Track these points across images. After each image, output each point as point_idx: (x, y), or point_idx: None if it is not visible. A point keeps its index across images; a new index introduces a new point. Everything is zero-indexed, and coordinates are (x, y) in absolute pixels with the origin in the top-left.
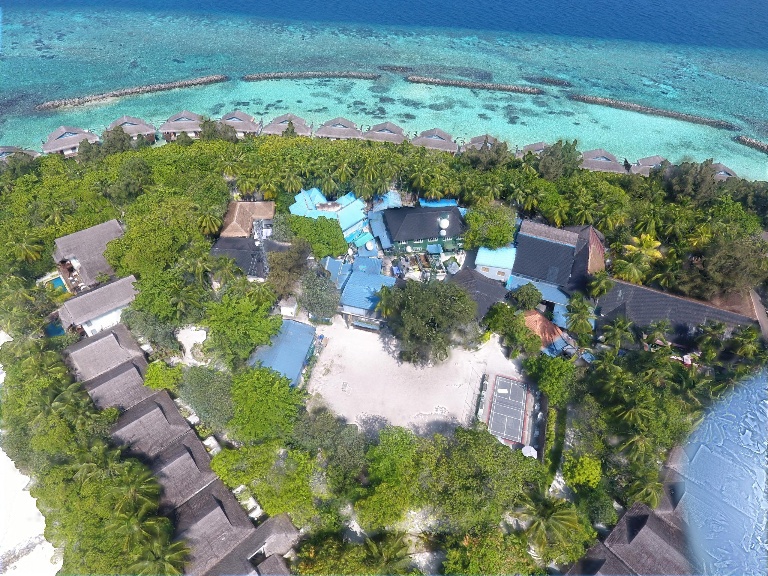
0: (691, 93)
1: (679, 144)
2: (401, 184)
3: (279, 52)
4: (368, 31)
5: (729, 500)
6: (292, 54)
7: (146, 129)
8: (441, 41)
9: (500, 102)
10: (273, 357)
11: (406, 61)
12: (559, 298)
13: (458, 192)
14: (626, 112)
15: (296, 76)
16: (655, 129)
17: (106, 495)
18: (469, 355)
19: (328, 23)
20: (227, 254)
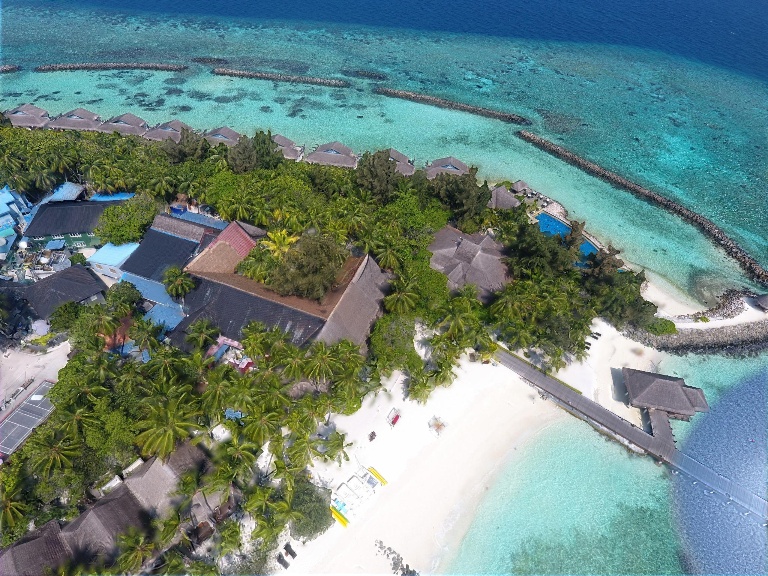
0: (507, 87)
1: (454, 138)
2: (76, 177)
3: (98, 43)
4: (213, 23)
5: (158, 519)
6: (111, 45)
7: None
8: (283, 34)
9: (296, 95)
10: None
11: (228, 53)
12: (161, 297)
13: (131, 185)
14: (423, 106)
15: (95, 67)
16: (440, 123)
17: None
18: (33, 358)
19: (176, 15)
20: None
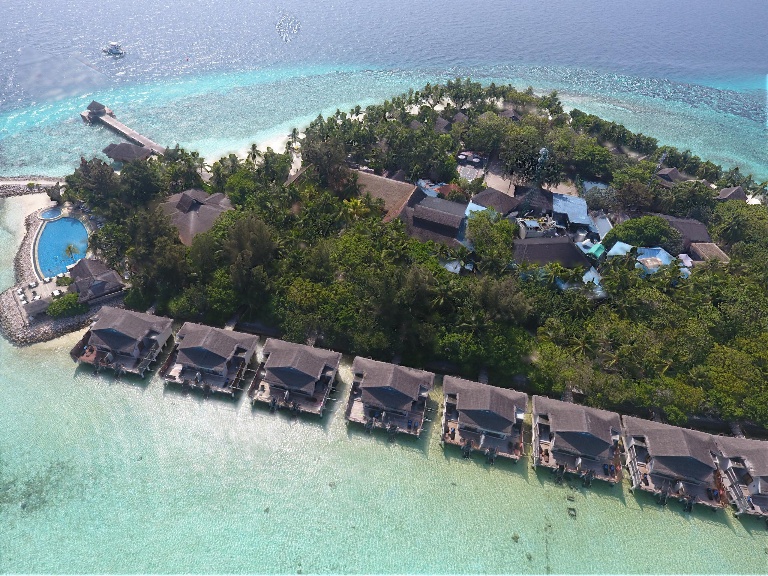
0: None
1: (3, 507)
2: None
3: None
4: None
5: None
6: None
7: None
8: None
9: None
10: (604, 187)
11: None
12: None
13: None
14: None
15: None
16: None
17: None
18: None
19: None
20: (688, 221)
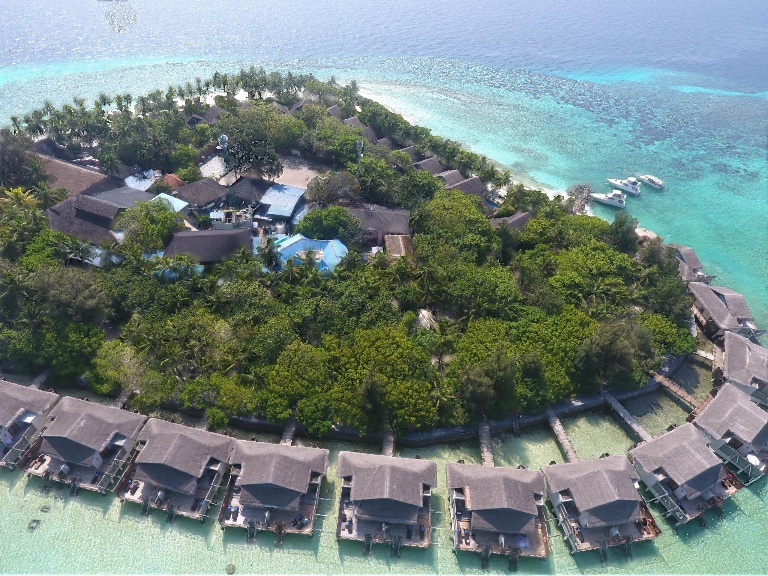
0: None
1: None
2: None
3: None
4: None
5: None
6: None
7: (647, 451)
8: None
9: None
10: None
11: None
12: None
13: None
14: None
15: None
16: None
17: (399, 121)
18: None
19: None
20: (395, 212)
